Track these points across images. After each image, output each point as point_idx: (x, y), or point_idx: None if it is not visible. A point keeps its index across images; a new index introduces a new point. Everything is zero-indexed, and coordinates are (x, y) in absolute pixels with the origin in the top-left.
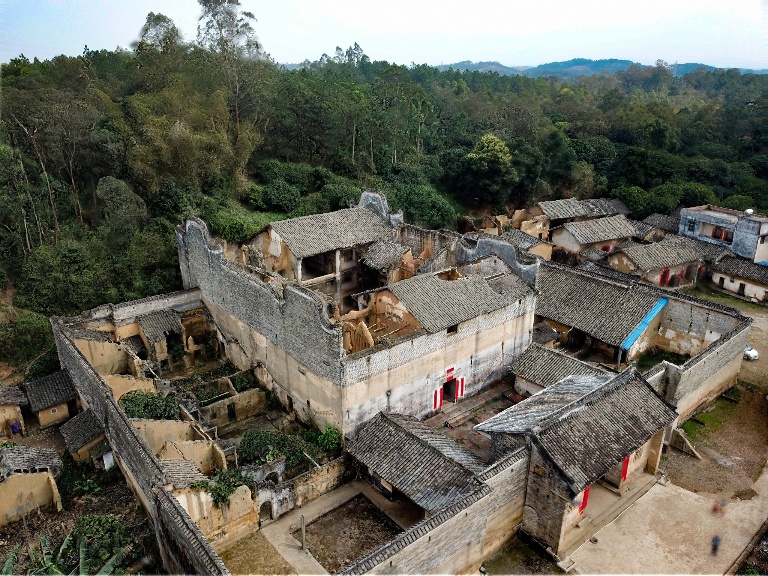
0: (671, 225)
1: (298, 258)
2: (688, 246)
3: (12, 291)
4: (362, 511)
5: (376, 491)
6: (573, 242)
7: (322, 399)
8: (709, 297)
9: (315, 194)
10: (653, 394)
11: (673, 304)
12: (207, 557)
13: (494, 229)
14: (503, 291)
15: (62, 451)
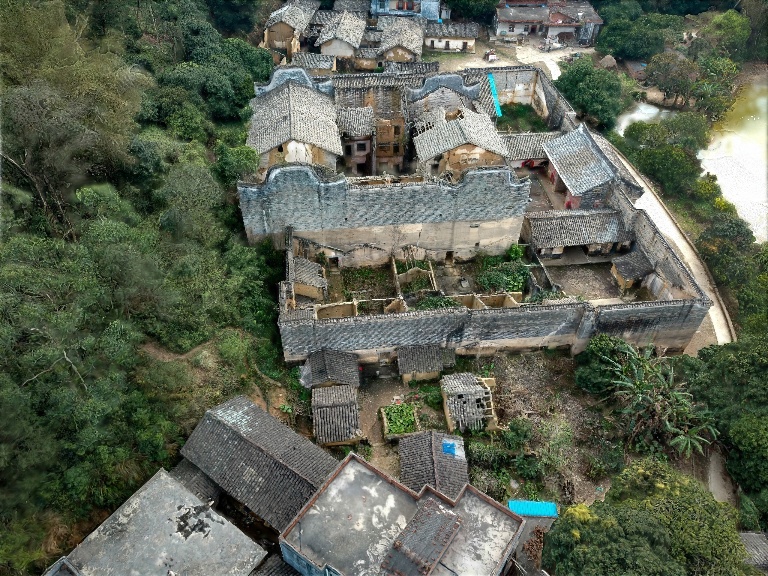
0: (359, 6)
1: (337, 156)
2: (412, 24)
3: (149, 348)
4: (559, 272)
5: (549, 260)
6: (346, 48)
7: (497, 234)
8: (436, 58)
9: (176, 90)
10: (593, 133)
11: (495, 75)
12: (664, 303)
13: (285, 59)
14: (478, 111)
15: (402, 388)
